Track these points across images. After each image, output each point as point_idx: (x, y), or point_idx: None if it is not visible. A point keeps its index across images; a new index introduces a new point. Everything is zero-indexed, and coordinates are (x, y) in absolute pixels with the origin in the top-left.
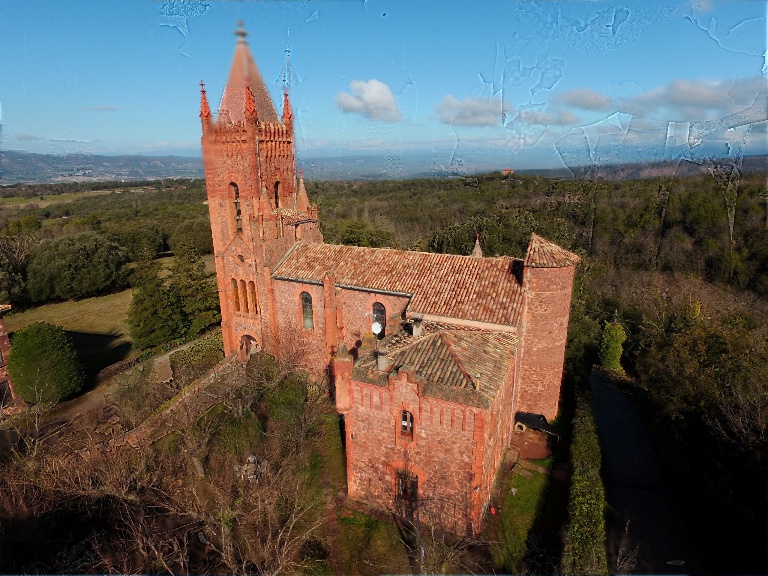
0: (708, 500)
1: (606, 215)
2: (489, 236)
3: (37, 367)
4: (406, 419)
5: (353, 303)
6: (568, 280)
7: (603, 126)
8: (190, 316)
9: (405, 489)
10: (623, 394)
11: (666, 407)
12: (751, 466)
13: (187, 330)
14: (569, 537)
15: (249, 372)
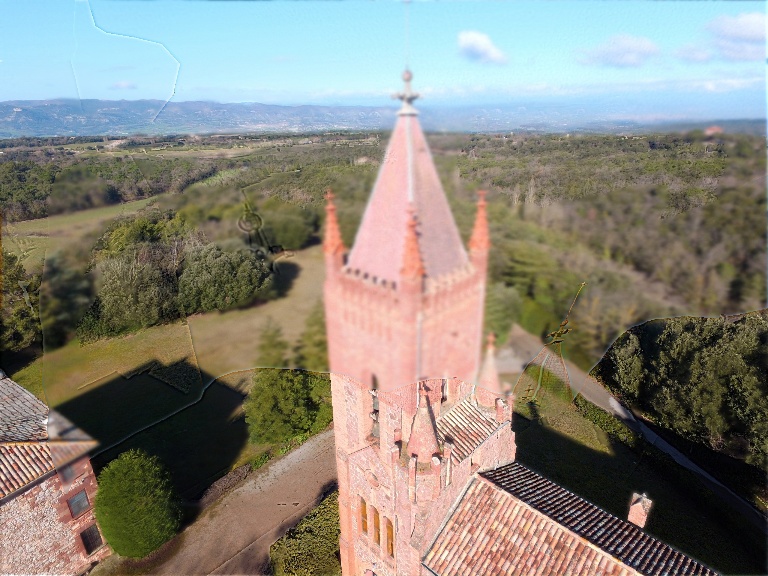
0: None
1: None
2: None
3: (122, 520)
4: None
5: None
6: None
7: None
8: None
9: None
10: None
11: None
12: None
13: (312, 423)
14: None
15: None
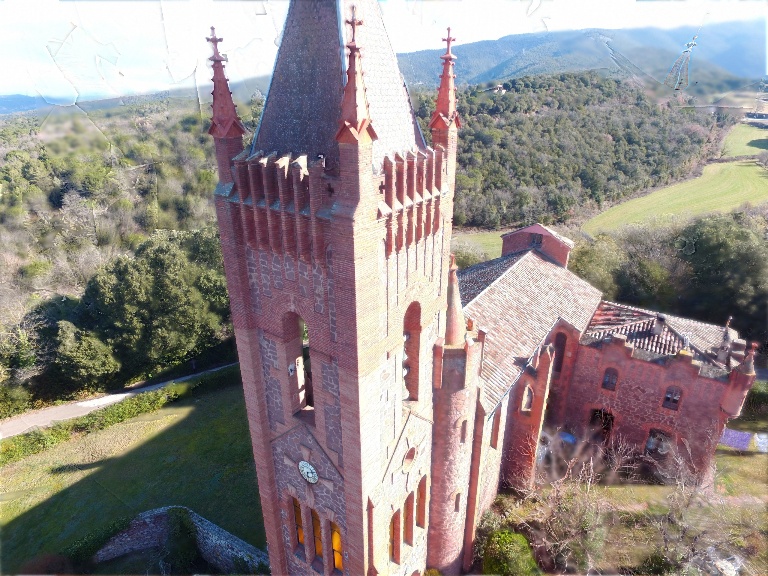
0: None
1: (169, 196)
2: None
3: None
4: None
5: None
6: None
7: None
8: None
9: None
10: None
11: None
12: None
13: None
14: None
15: None
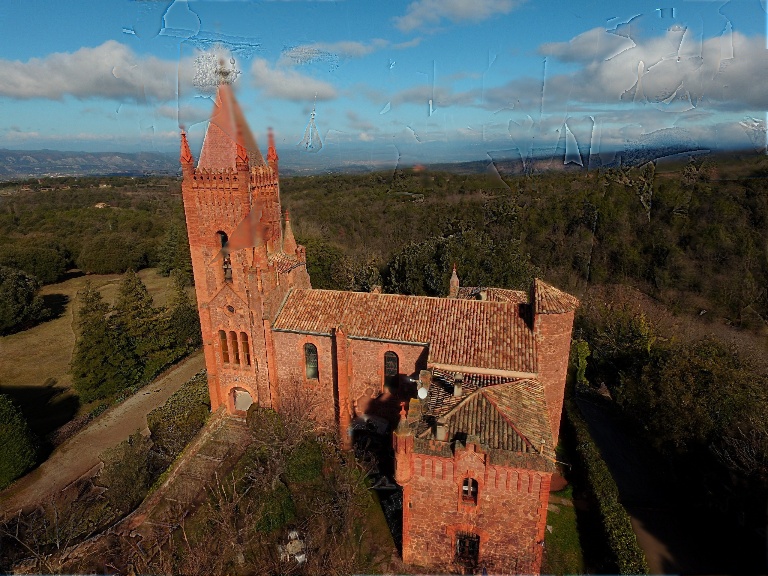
0: (701, 509)
1: (539, 225)
2: (452, 258)
3: None
4: (467, 484)
5: (363, 353)
6: (571, 322)
7: (531, 142)
8: (141, 358)
9: (463, 548)
10: (597, 407)
11: (668, 434)
12: (762, 492)
13: (141, 374)
14: (623, 574)
15: (254, 431)
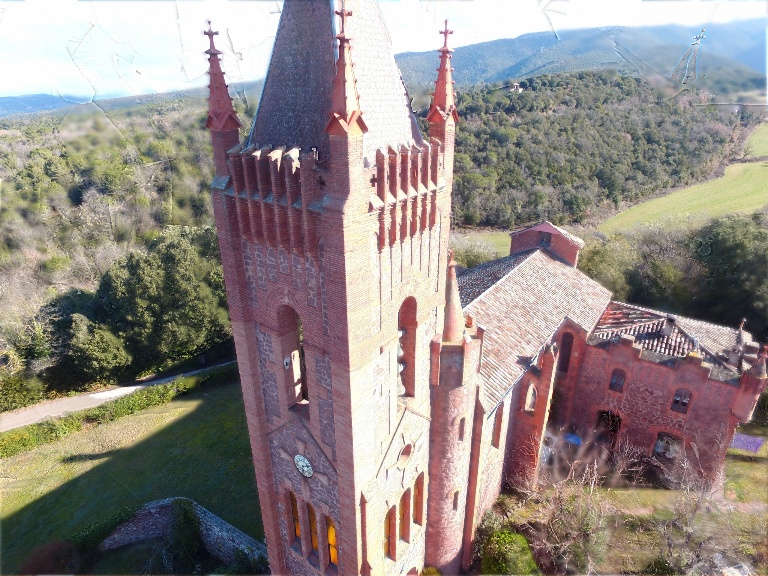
0: None
1: (183, 193)
2: None
3: None
4: None
5: None
6: None
7: None
8: None
9: None
10: None
11: None
12: None
13: None
14: None
15: None
